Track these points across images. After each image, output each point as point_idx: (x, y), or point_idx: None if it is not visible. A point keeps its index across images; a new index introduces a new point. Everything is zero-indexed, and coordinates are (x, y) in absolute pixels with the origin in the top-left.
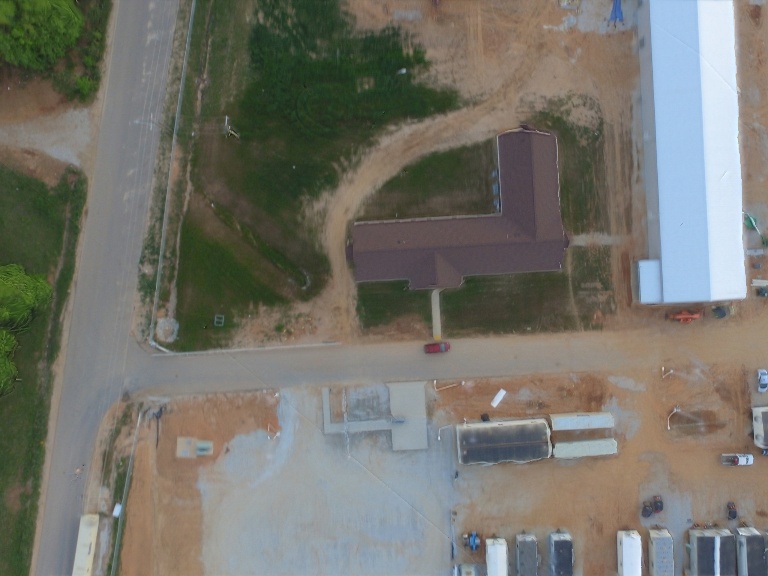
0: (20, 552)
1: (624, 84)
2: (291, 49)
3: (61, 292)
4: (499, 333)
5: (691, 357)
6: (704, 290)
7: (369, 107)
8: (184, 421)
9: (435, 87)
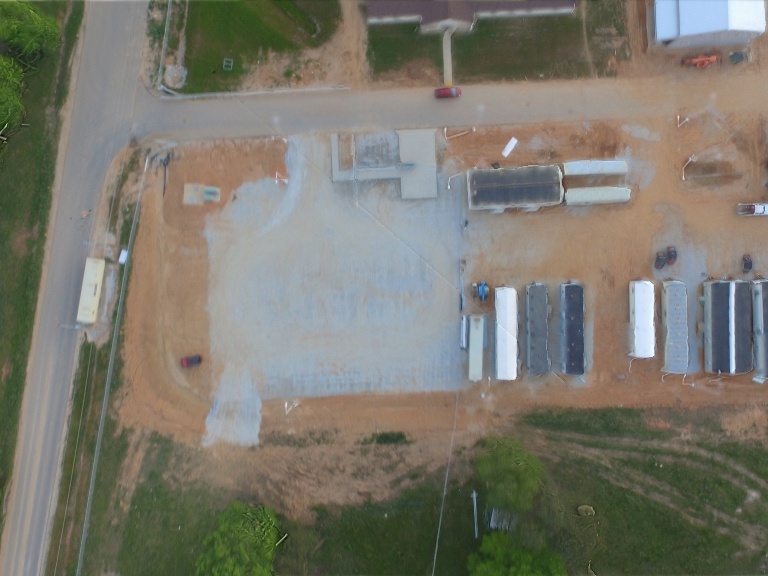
0: (26, 297)
1: None
2: None
3: (70, 37)
4: (511, 80)
5: (707, 106)
6: (722, 19)
7: None
8: (191, 168)
9: None
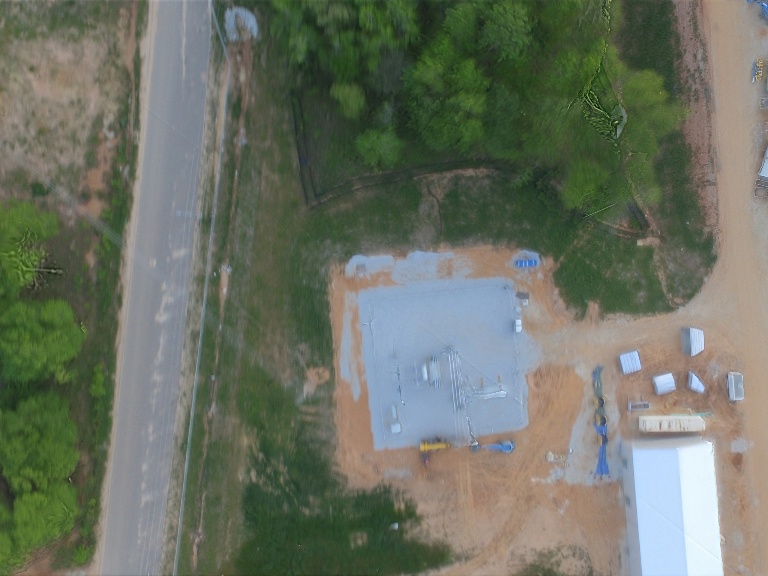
0: None
1: (612, 533)
2: (284, 506)
3: None
4: None
5: None
6: None
7: (363, 565)
8: None
9: (427, 542)
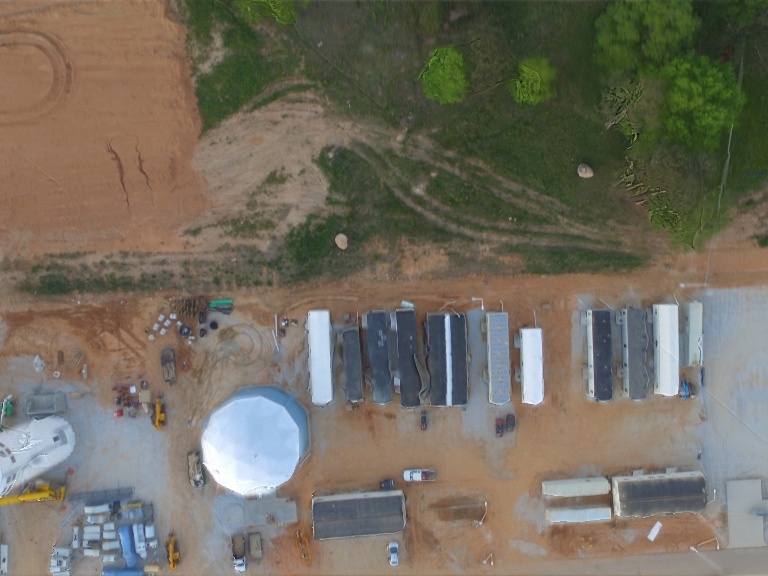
0: None
1: None
2: None
3: None
4: None
5: (465, 575)
6: None
7: None
8: None
9: None
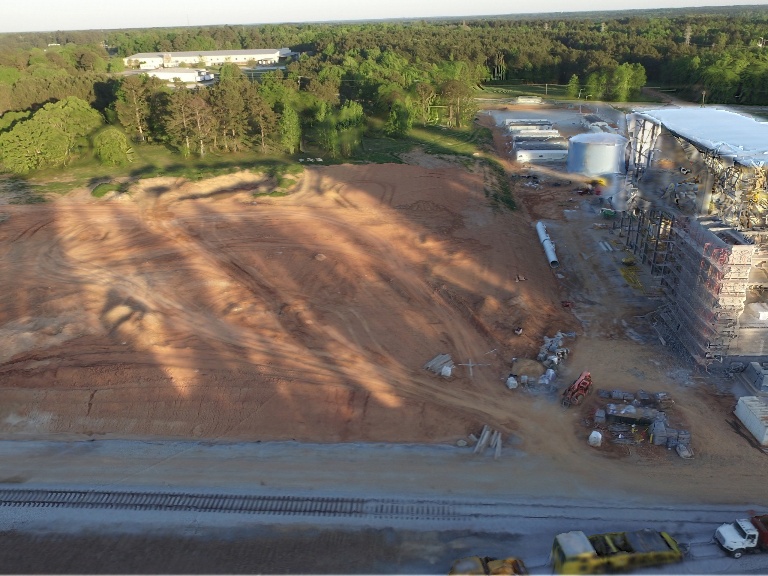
0: None
1: None
2: None
3: None
4: None
5: None
6: None
7: None
8: None
9: None
